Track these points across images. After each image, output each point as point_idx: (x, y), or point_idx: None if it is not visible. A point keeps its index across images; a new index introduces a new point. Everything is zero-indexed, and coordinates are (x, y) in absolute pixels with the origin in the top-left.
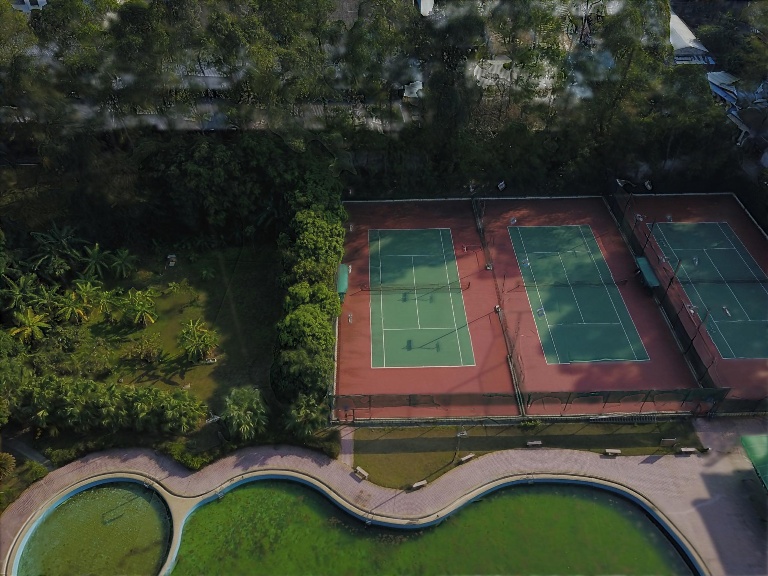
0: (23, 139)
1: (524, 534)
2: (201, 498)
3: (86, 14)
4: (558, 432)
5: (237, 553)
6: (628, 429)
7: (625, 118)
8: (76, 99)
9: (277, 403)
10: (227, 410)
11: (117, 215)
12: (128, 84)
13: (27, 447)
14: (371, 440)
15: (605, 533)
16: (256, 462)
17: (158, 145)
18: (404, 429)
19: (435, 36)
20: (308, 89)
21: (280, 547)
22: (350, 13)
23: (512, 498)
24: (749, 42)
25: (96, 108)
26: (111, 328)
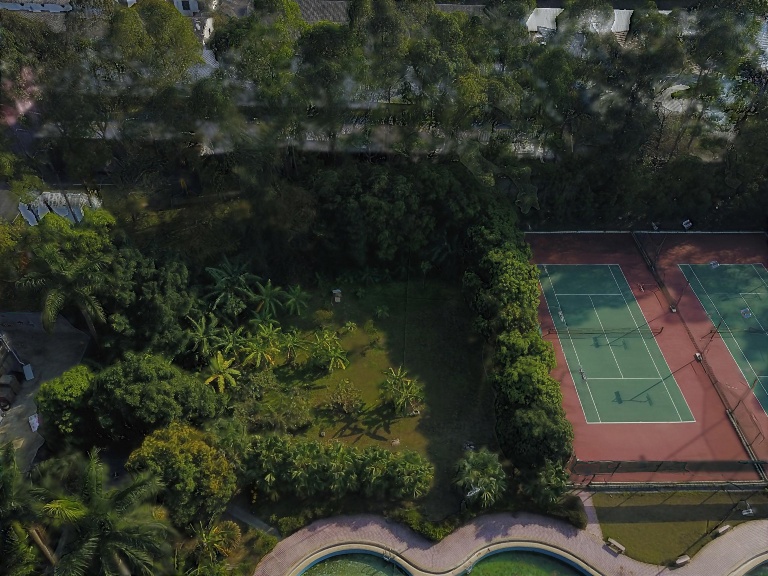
0: (176, 162)
1: None
2: (451, 574)
3: (284, 37)
4: None
5: None
6: None
7: None
8: (256, 125)
9: None
10: (463, 474)
11: (286, 248)
12: (320, 112)
13: (243, 512)
14: (612, 507)
15: None
16: (498, 532)
17: None
18: (644, 494)
19: (632, 67)
20: (483, 117)
21: None
22: None
23: None
24: None
25: (276, 135)
26: (294, 373)
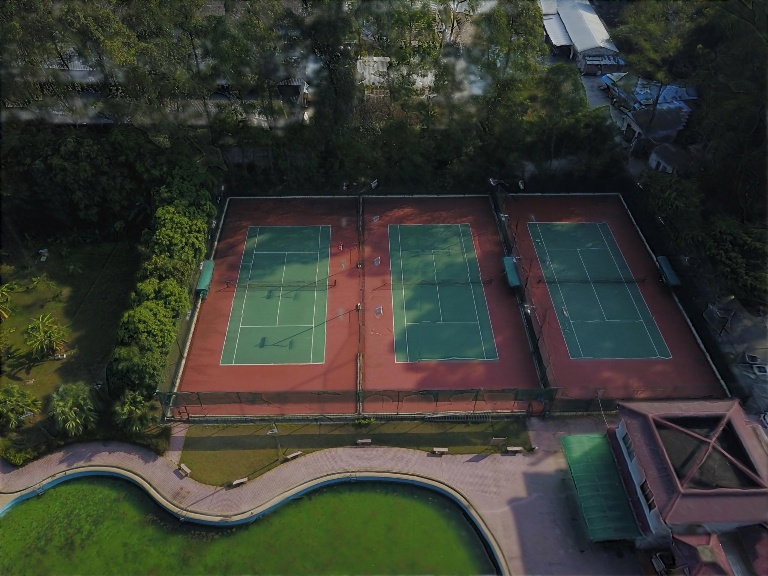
0: None
1: (336, 532)
2: (19, 494)
3: None
4: (391, 430)
5: (46, 549)
6: (461, 428)
7: (501, 117)
8: None
9: None
10: None
11: None
12: None
13: None
14: (203, 437)
15: (417, 531)
16: (82, 458)
17: (23, 139)
18: (238, 426)
19: (303, 33)
20: None
21: (90, 544)
22: None
23: (333, 496)
24: (636, 43)
25: None
26: None
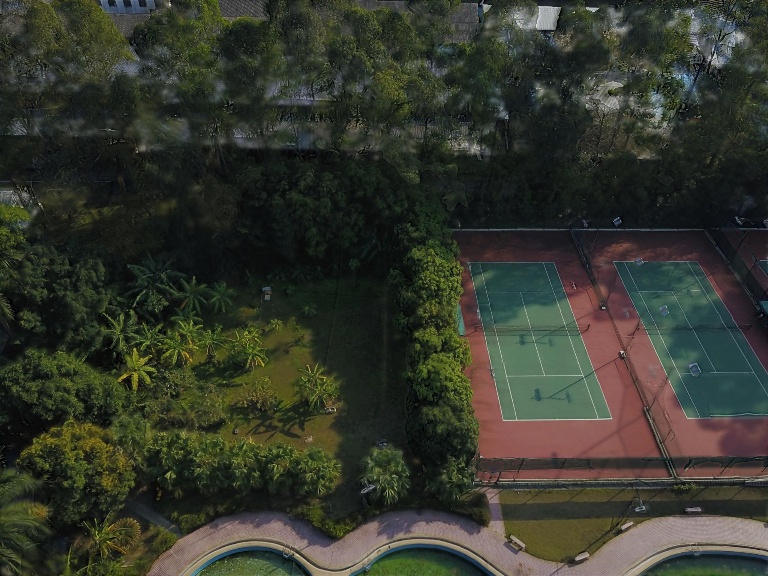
0: (106, 159)
1: None
2: (349, 571)
3: (199, 33)
4: (714, 497)
5: None
6: None
7: (743, 152)
8: (178, 122)
9: (410, 460)
10: (367, 472)
11: (213, 245)
12: (239, 109)
13: (147, 509)
14: (519, 504)
15: None
16: (400, 529)
17: (261, 172)
18: (551, 492)
19: (558, 63)
20: (414, 114)
21: None
22: None
23: (679, 572)
24: None
25: (199, 132)
26: (215, 370)
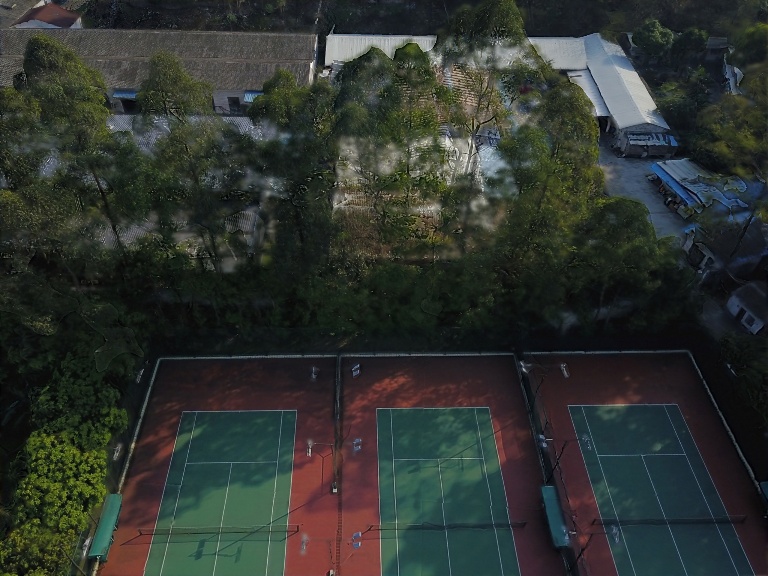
0: None
1: None
2: None
3: None
4: None
5: None
6: None
7: (536, 270)
8: None
9: None
10: None
11: None
12: None
13: None
14: None
15: None
16: None
17: None
18: None
19: (250, 164)
20: (83, 224)
21: None
22: (229, 64)
23: None
24: None
25: None
26: None
